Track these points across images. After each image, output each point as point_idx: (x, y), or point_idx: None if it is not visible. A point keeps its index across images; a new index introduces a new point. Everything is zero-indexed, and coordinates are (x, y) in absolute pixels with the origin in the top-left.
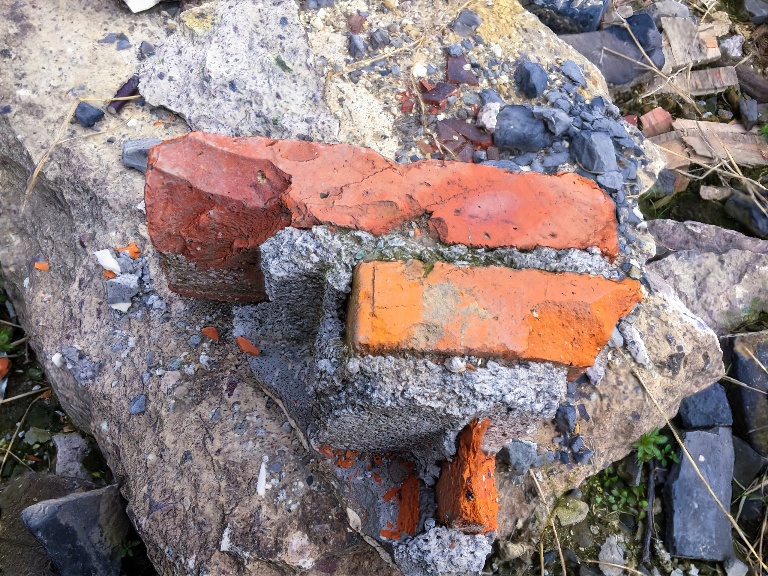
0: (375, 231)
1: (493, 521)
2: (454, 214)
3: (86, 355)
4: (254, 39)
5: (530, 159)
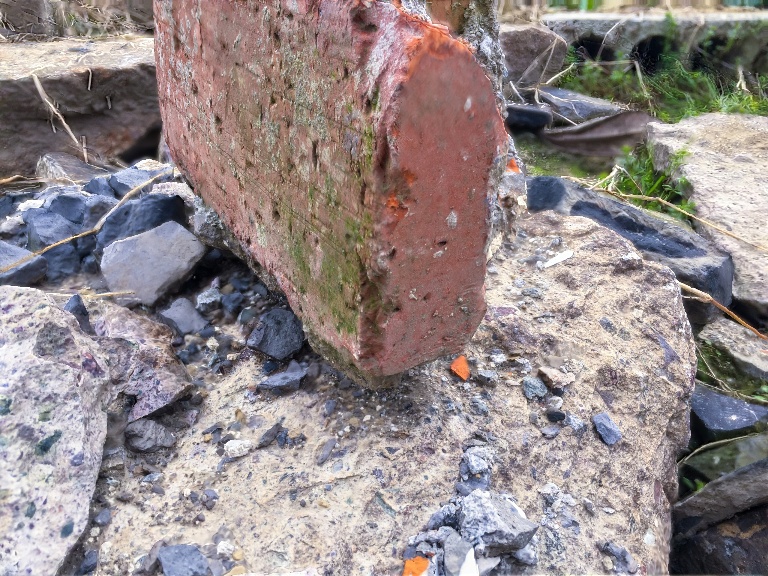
0: None
1: None
2: None
3: None
4: None
5: None
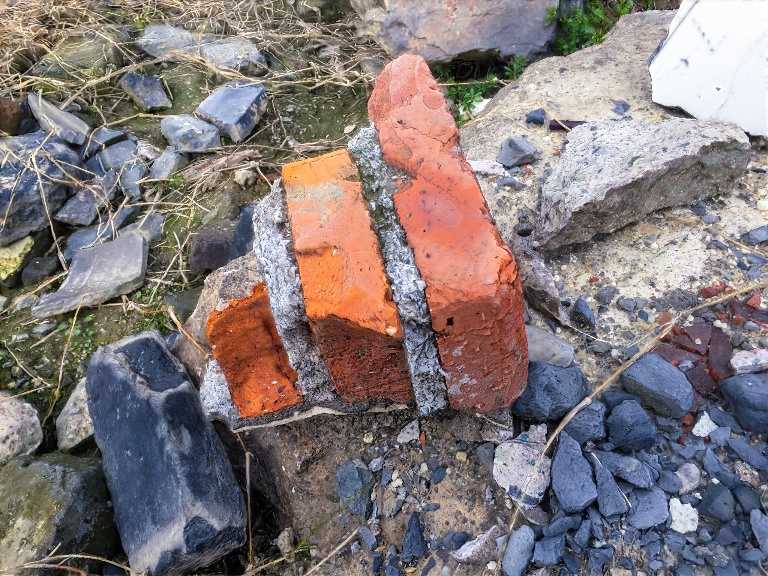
0: (385, 157)
1: (248, 410)
2: (420, 191)
3: None
4: (655, 142)
5: (726, 423)
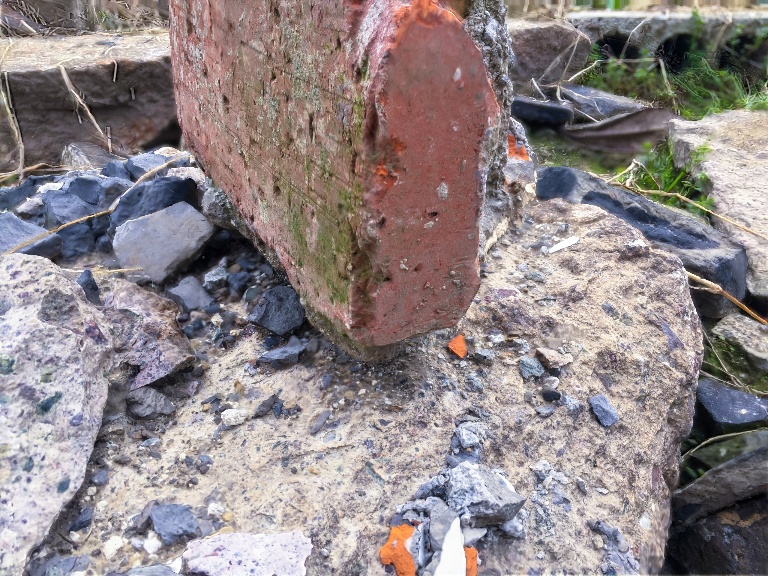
0: None
1: None
2: None
3: (604, 575)
4: None
5: None
